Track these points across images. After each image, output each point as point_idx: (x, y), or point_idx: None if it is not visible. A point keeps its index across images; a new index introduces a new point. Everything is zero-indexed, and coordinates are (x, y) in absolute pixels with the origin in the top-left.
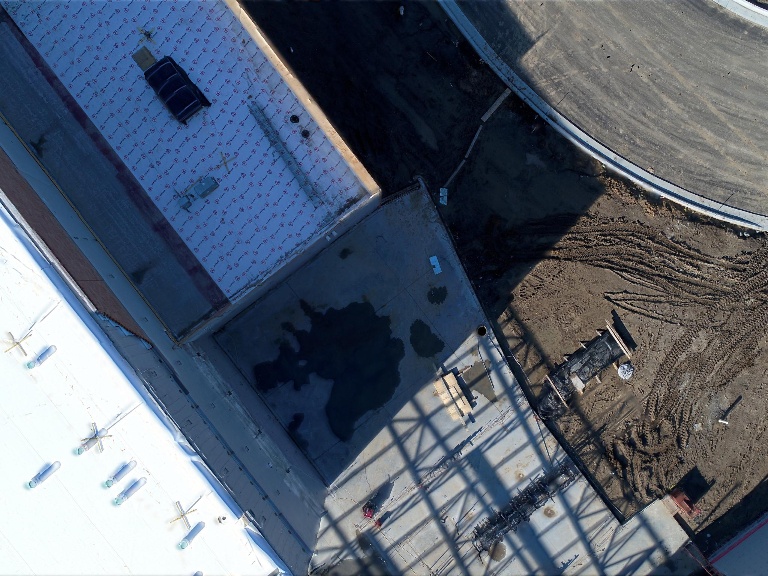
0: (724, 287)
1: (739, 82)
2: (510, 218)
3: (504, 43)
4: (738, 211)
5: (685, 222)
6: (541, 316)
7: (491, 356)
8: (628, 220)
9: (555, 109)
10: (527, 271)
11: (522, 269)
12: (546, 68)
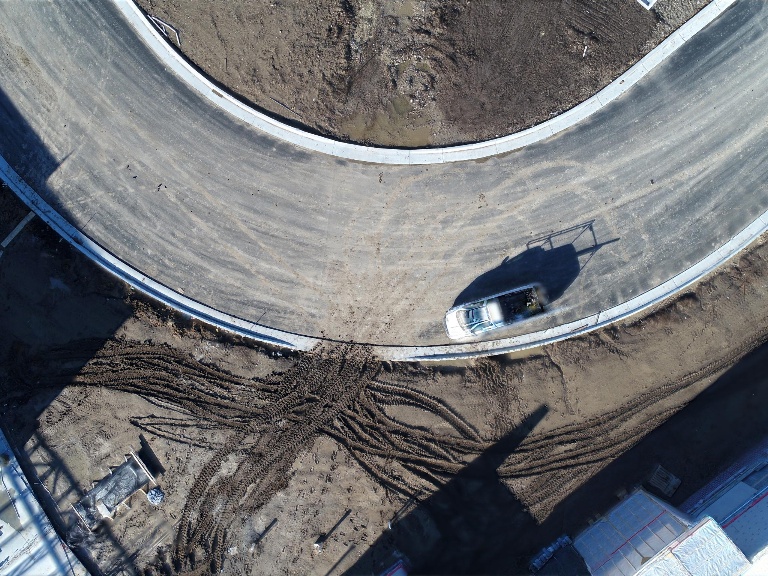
0: (255, 409)
1: (269, 199)
2: (34, 344)
3: (28, 166)
4: (270, 330)
5: (214, 343)
6: (69, 442)
7: (15, 485)
8: (155, 343)
9: (81, 231)
10: (53, 397)
11: (48, 395)
12: (72, 190)
